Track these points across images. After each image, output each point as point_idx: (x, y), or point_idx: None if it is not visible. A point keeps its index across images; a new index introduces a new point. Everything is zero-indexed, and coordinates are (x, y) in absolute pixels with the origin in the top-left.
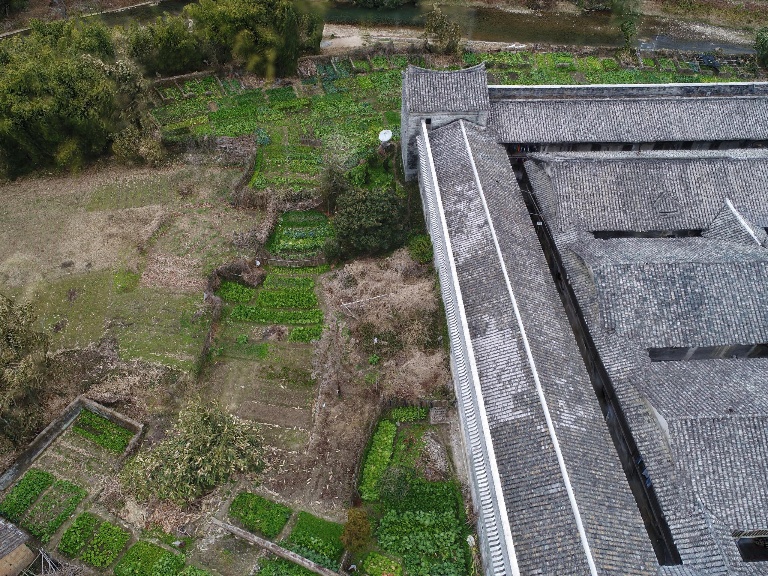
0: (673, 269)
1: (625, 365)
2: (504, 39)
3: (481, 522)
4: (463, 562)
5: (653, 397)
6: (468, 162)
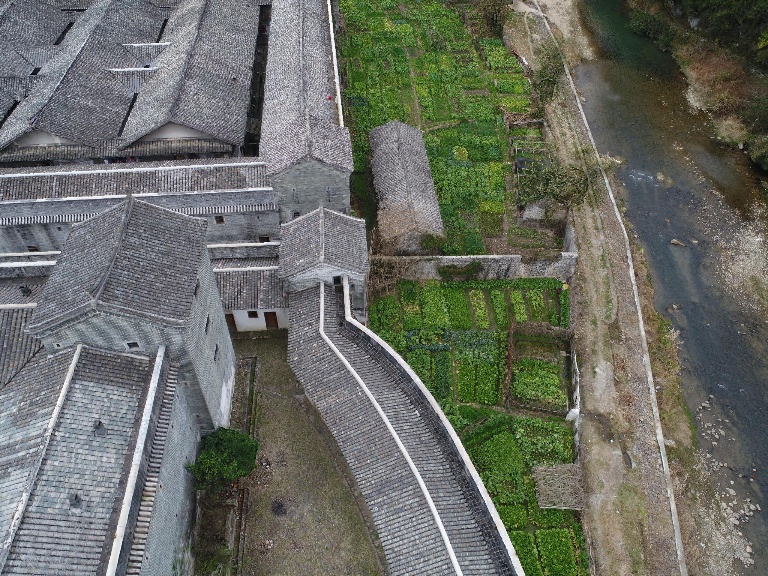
0: (105, 7)
1: None
2: (599, 86)
3: None
4: None
5: (38, 1)
6: None
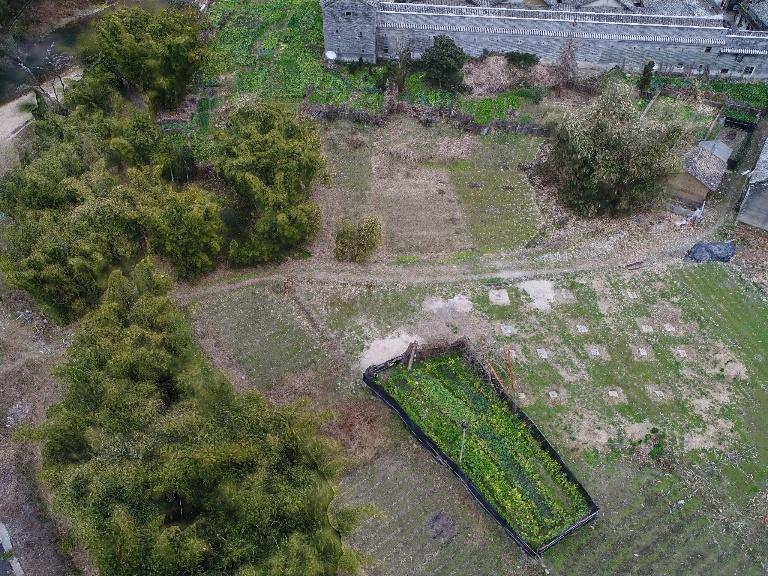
0: None
1: (569, 7)
2: None
3: (629, 62)
4: (639, 77)
5: None
6: (426, 8)
